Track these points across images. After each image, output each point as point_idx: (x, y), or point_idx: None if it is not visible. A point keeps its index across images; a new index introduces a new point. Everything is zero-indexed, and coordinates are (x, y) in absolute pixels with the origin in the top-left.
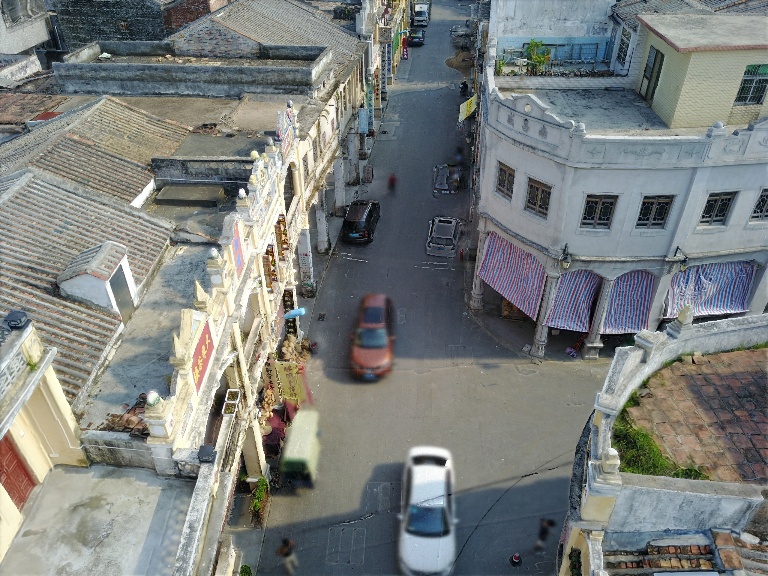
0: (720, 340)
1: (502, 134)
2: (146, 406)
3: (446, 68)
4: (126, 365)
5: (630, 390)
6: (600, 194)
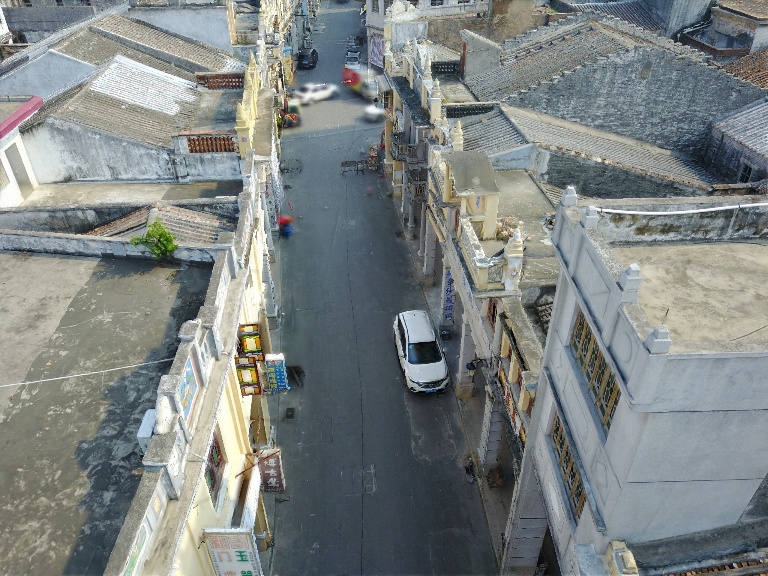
0: (435, 12)
1: None
2: (259, 13)
3: (354, 1)
4: None
5: (403, 20)
6: None
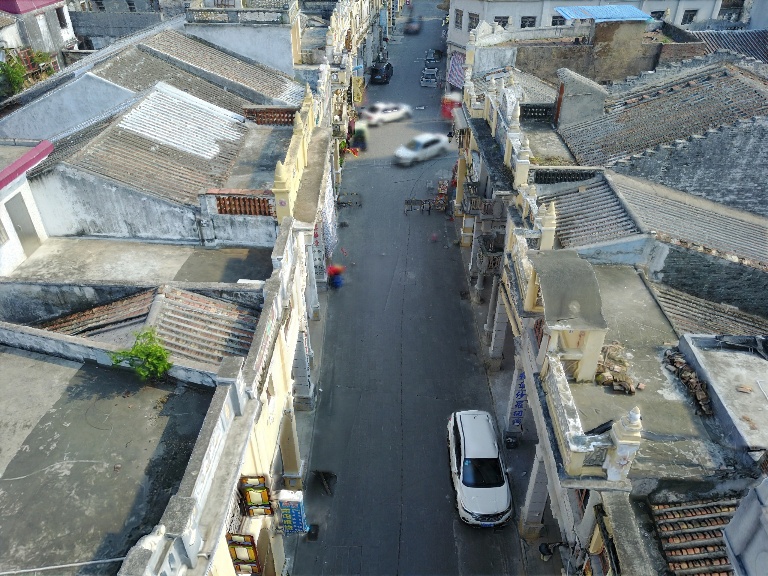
0: (525, 35)
1: None
2: (327, 31)
3: (437, 9)
4: (305, 47)
5: (488, 43)
6: (501, 16)
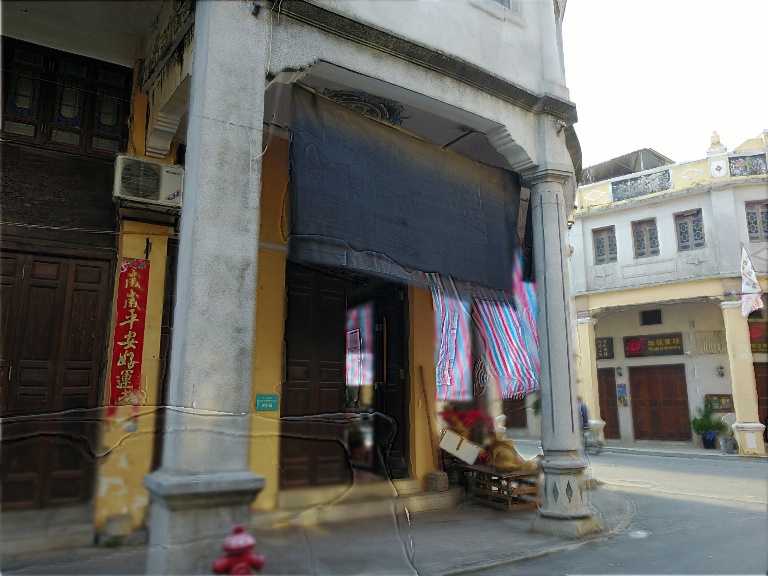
0: None
1: None
2: None
3: None
4: None
5: None
6: None
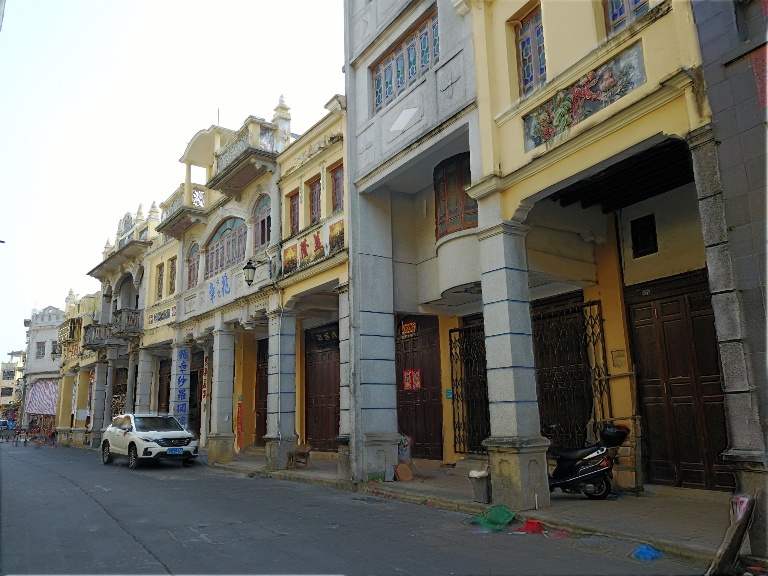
0: None
1: (39, 327)
2: None
3: None
4: None
5: None
6: None
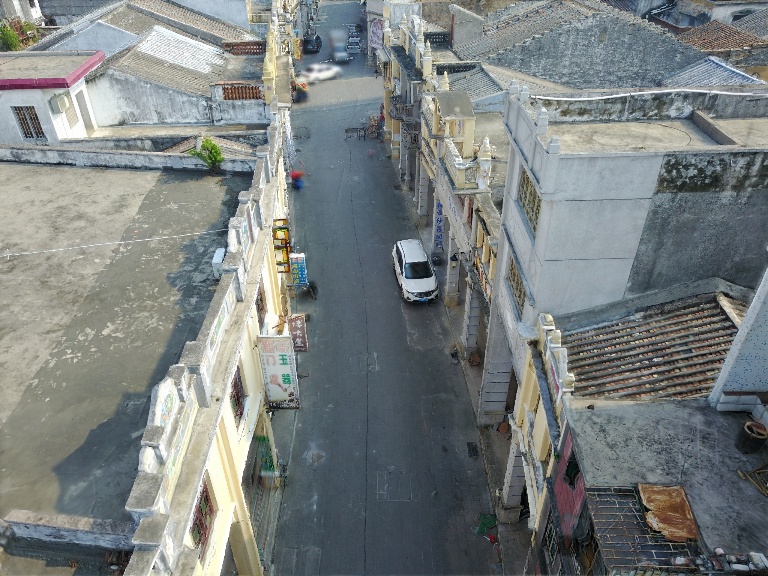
0: None
1: None
2: None
3: None
4: None
5: (400, 2)
6: None
